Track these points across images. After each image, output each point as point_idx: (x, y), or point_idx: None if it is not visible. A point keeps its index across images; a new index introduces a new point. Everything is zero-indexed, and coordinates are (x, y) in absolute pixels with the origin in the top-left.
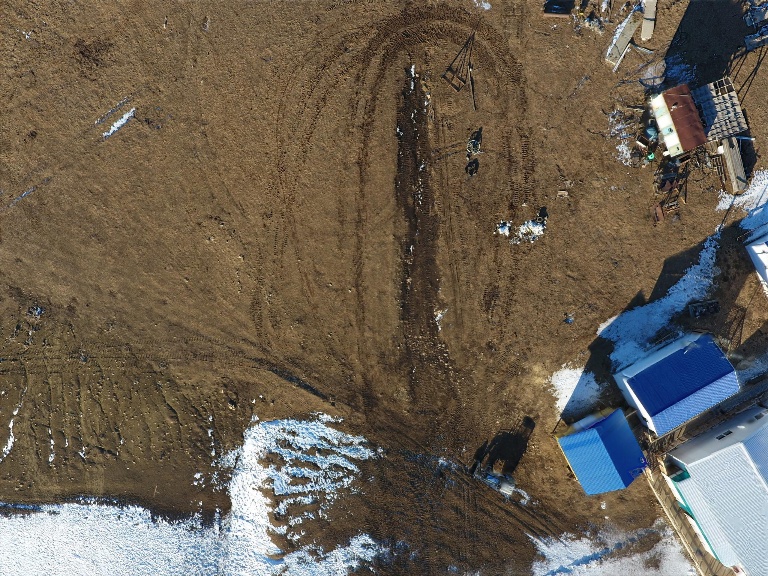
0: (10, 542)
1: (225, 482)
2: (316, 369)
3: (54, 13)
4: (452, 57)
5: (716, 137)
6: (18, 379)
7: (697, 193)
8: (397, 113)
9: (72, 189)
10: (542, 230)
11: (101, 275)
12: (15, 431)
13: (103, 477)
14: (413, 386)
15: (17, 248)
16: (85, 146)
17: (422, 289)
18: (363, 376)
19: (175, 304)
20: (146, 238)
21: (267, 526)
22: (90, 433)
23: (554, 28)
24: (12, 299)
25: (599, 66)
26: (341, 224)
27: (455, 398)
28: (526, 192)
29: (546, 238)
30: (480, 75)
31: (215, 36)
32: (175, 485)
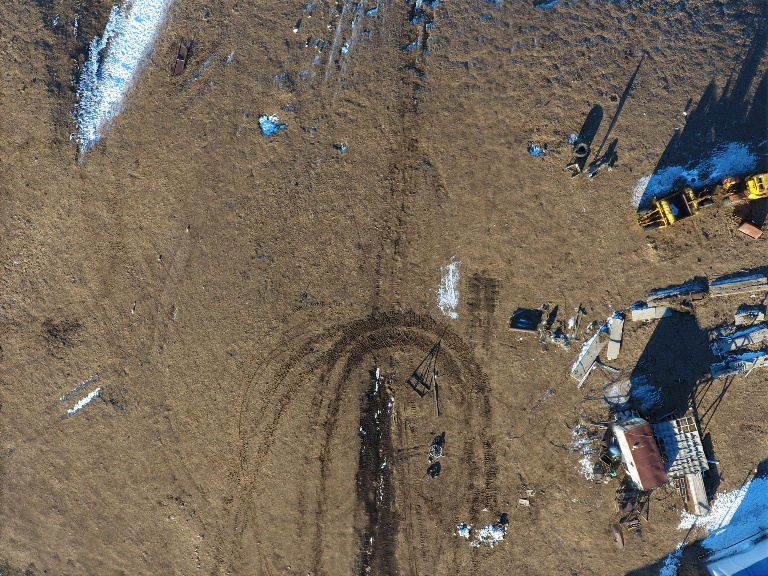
0: None
1: None
2: None
3: (24, 291)
4: (417, 363)
5: (677, 473)
6: None
7: (659, 511)
8: (360, 414)
9: (34, 461)
10: (502, 536)
11: (60, 544)
12: None
13: None
14: None
15: None
16: (49, 421)
17: None
18: None
19: (133, 575)
20: (106, 512)
21: None
22: None
23: (520, 341)
24: None
25: (564, 381)
26: (301, 513)
27: None
28: (487, 497)
29: (506, 544)
30: (445, 382)
31: (182, 326)
32: None
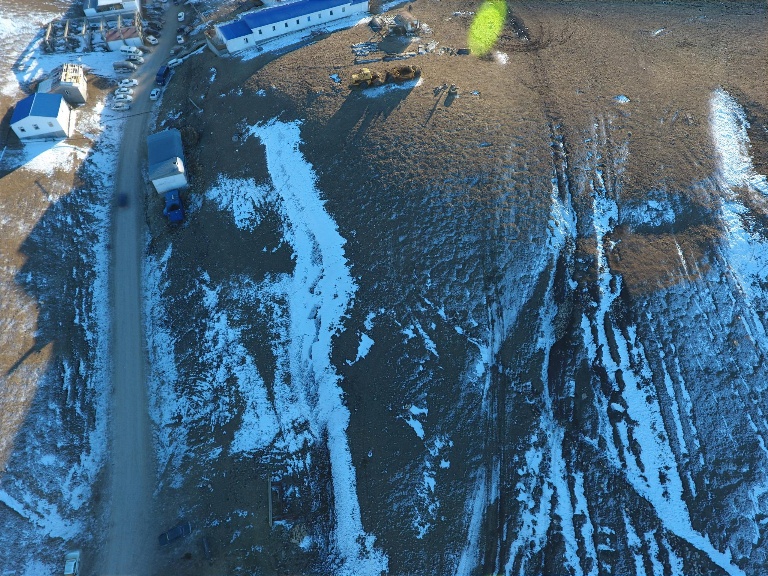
0: None
1: None
2: None
3: None
4: None
5: None
6: None
7: None
8: None
9: None
10: None
11: None
12: None
13: None
14: None
15: None
16: None
17: (501, 7)
18: None
19: None
20: None
21: None
22: None
23: None
24: None
25: None
26: None
27: None
28: None
29: None
30: None
31: None
32: None
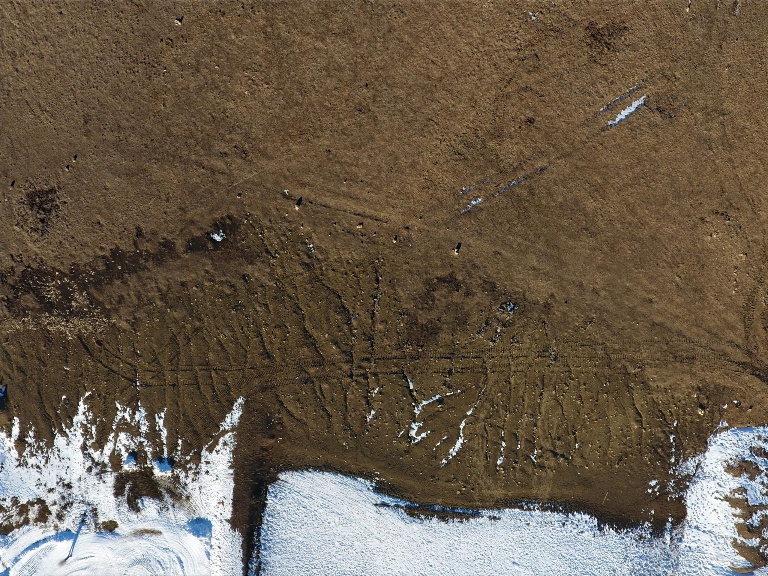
0: (445, 547)
1: (681, 490)
2: None
3: None
4: None
5: None
6: (478, 377)
7: None
8: None
9: (568, 179)
10: None
11: (586, 270)
12: (466, 432)
13: (551, 482)
14: None
15: (498, 240)
16: (587, 134)
17: None
18: None
19: (662, 303)
20: (641, 233)
21: (734, 538)
22: (545, 436)
23: None
24: (484, 293)
25: None
26: None
27: None
28: None
29: None
30: None
31: (746, 21)
32: (627, 492)
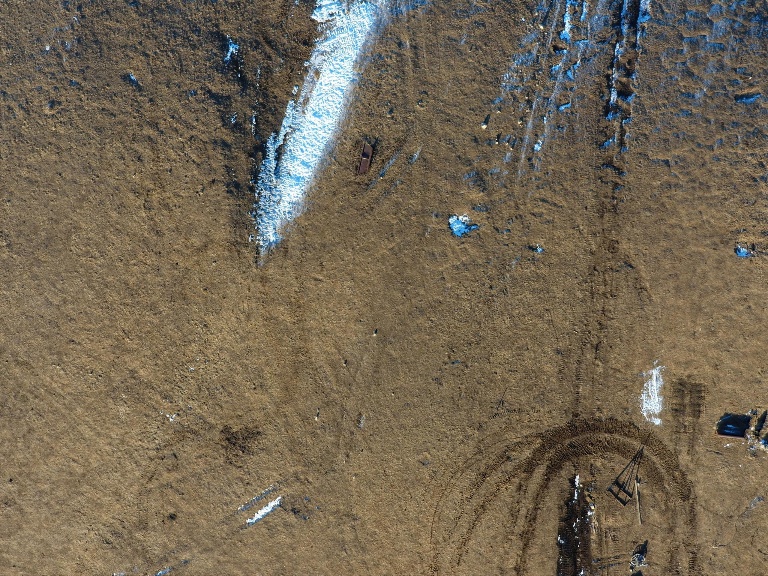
0: None
1: None
2: None
3: (200, 398)
4: (619, 470)
5: None
6: None
7: None
8: (559, 523)
9: (211, 573)
10: None
11: None
12: None
13: None
14: None
15: None
16: (227, 532)
17: None
18: None
19: None
20: None
21: None
22: None
23: (727, 447)
24: None
25: None
26: None
27: None
28: None
29: None
30: (647, 489)
31: (370, 434)
32: None
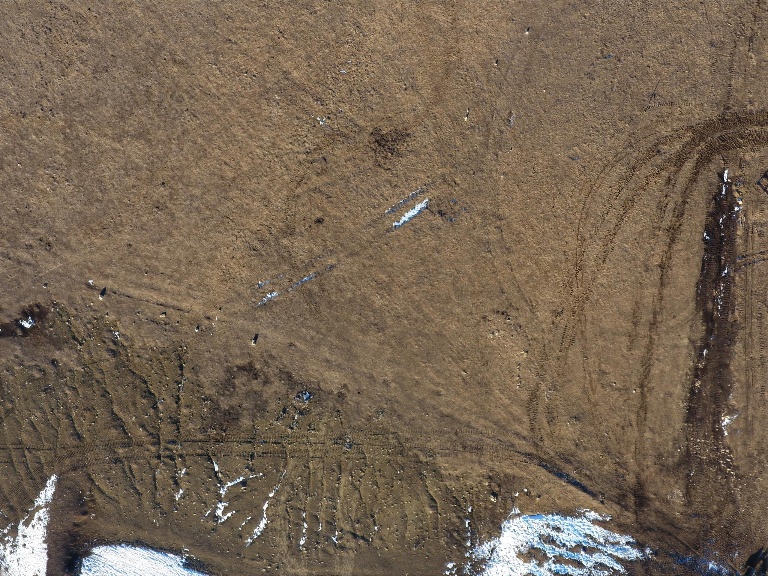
0: None
1: (478, 573)
2: (588, 466)
3: (351, 100)
4: None
5: None
6: (278, 462)
7: None
8: (706, 218)
9: (356, 277)
10: None
11: (376, 363)
12: (269, 513)
13: (353, 562)
14: (689, 489)
15: (292, 332)
16: (373, 235)
17: (711, 393)
18: (637, 476)
19: (450, 395)
20: (427, 329)
21: None
22: (345, 518)
23: None
24: (281, 383)
25: None
26: (634, 325)
27: (733, 503)
28: None
29: None
30: None
31: (520, 132)
32: (426, 574)
